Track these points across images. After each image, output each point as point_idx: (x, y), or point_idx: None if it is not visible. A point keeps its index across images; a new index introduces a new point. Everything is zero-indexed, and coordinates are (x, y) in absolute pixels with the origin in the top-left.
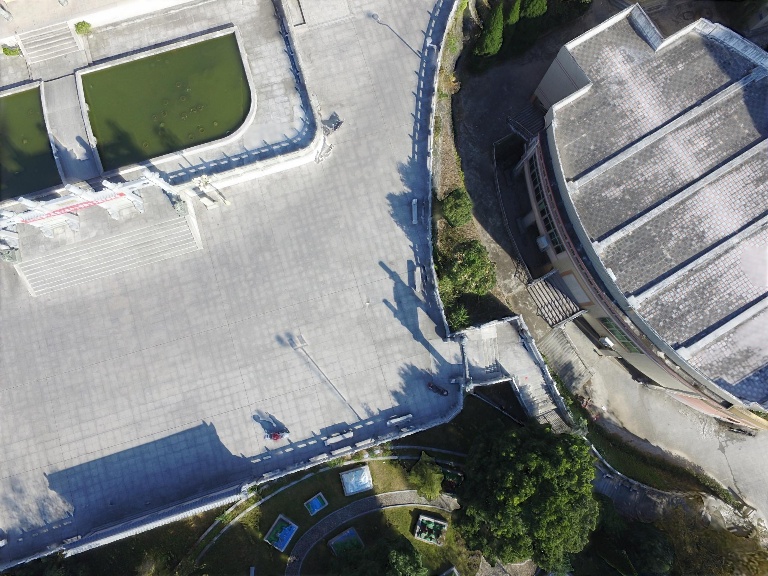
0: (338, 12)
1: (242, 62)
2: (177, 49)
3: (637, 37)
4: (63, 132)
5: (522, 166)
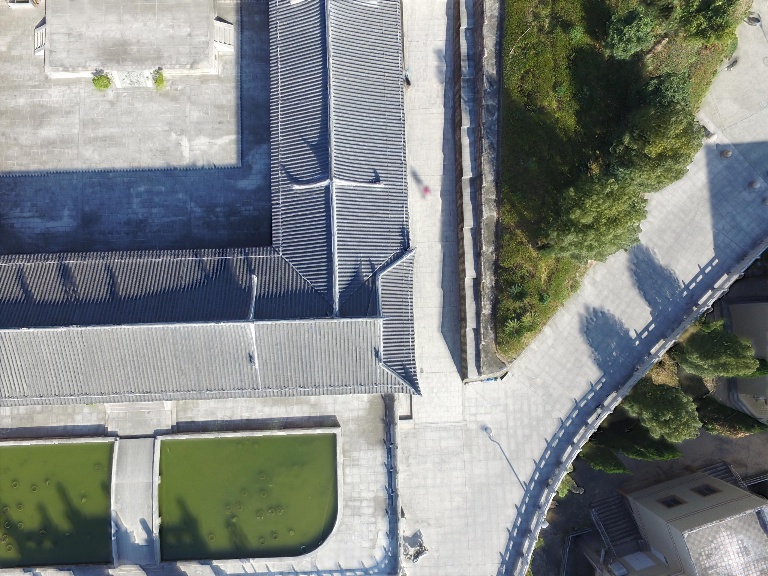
0: (450, 415)
1: (336, 471)
2: (270, 435)
3: (759, 528)
4: (127, 509)
5: (593, 566)
